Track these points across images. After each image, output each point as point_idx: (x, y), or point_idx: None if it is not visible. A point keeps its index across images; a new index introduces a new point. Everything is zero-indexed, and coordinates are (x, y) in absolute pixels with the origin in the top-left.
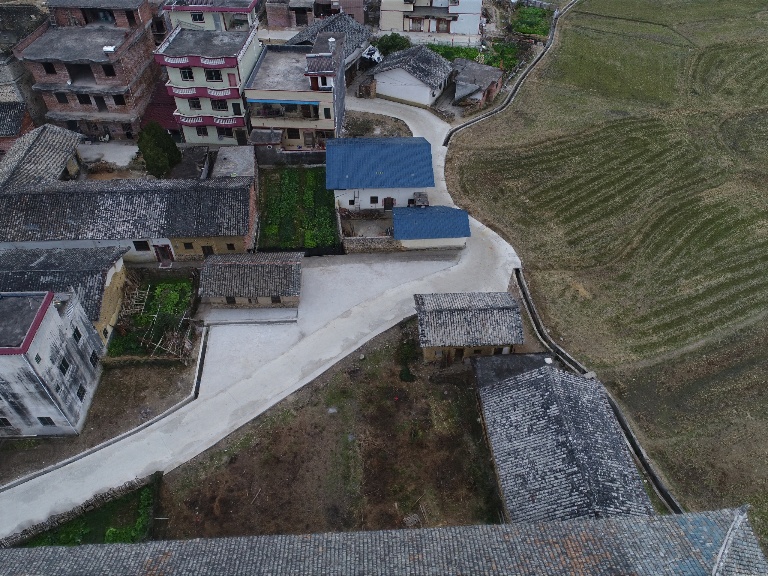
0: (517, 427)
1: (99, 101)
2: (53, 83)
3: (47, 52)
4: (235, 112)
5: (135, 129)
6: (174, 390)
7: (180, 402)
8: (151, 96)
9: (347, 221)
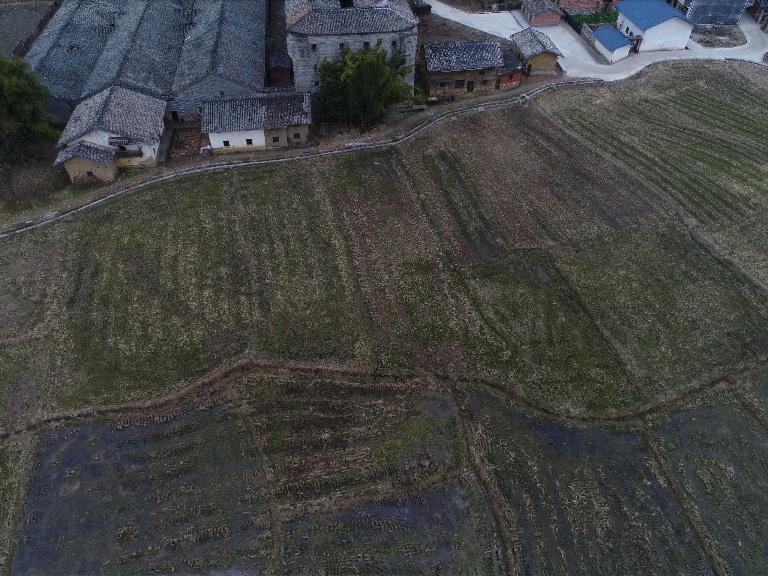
0: None
1: None
2: None
3: None
4: None
5: None
6: (472, 11)
7: None
8: None
9: None
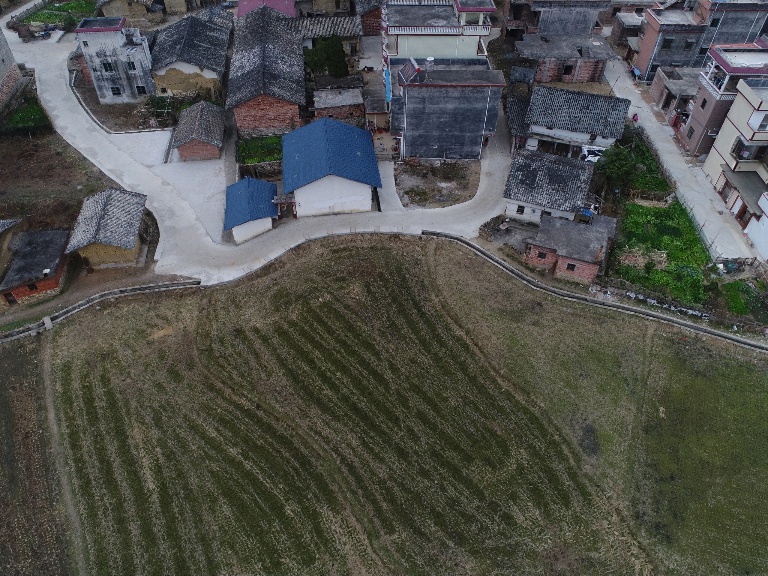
0: None
1: None
2: None
3: None
4: None
5: None
6: (122, 127)
7: (109, 129)
8: None
9: None
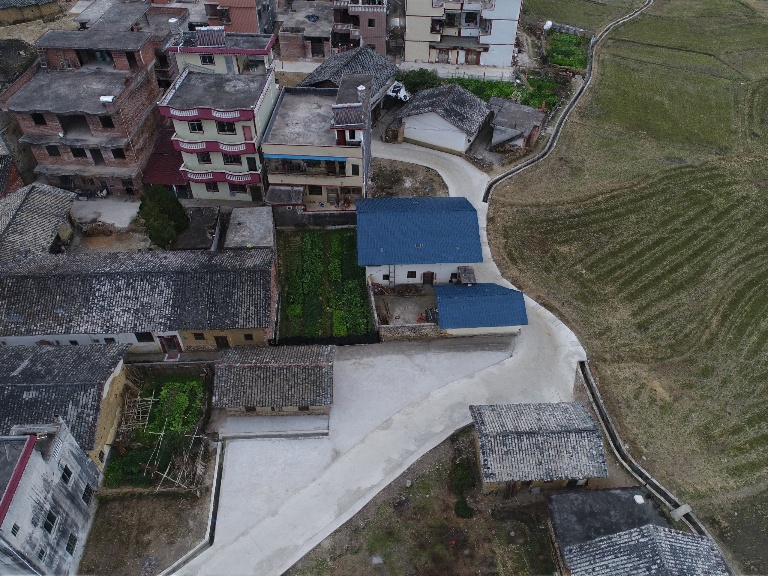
0: None
1: (95, 154)
2: (43, 135)
3: (36, 101)
4: (250, 167)
5: (136, 184)
6: (184, 531)
7: (192, 550)
8: (154, 145)
9: (380, 298)
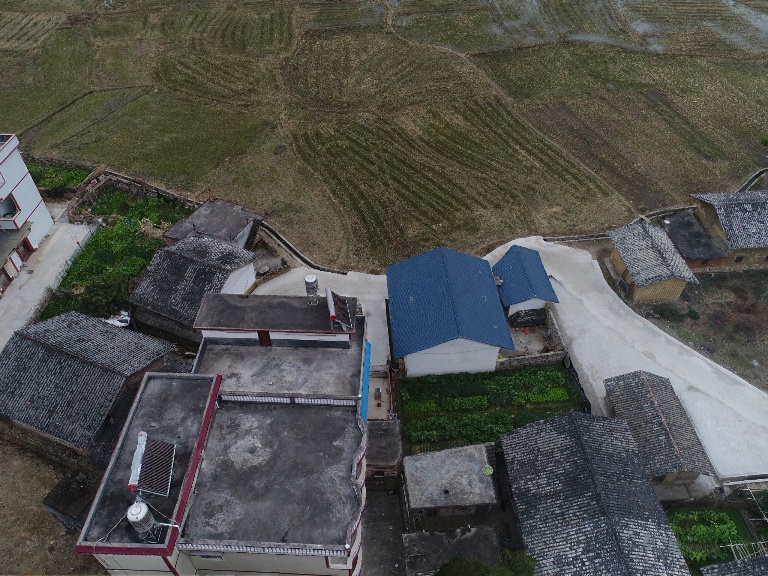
0: (761, 229)
1: None
2: None
3: None
4: None
5: None
6: None
7: None
8: None
9: None
